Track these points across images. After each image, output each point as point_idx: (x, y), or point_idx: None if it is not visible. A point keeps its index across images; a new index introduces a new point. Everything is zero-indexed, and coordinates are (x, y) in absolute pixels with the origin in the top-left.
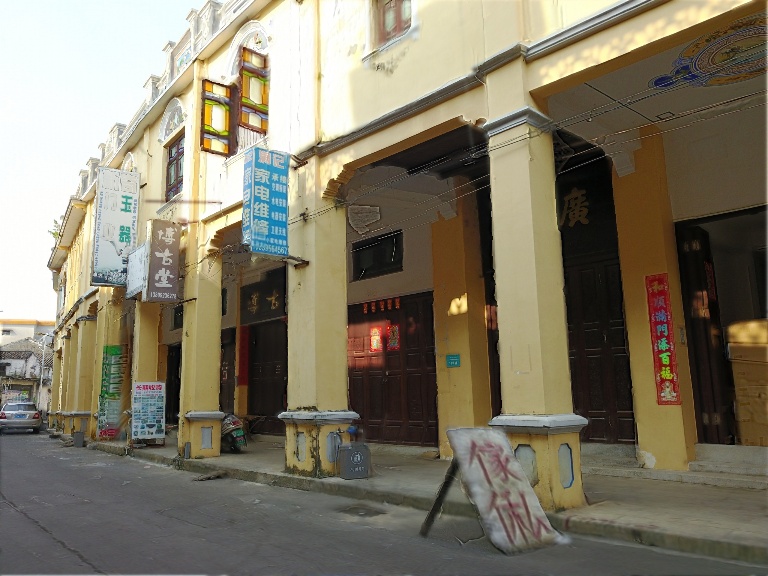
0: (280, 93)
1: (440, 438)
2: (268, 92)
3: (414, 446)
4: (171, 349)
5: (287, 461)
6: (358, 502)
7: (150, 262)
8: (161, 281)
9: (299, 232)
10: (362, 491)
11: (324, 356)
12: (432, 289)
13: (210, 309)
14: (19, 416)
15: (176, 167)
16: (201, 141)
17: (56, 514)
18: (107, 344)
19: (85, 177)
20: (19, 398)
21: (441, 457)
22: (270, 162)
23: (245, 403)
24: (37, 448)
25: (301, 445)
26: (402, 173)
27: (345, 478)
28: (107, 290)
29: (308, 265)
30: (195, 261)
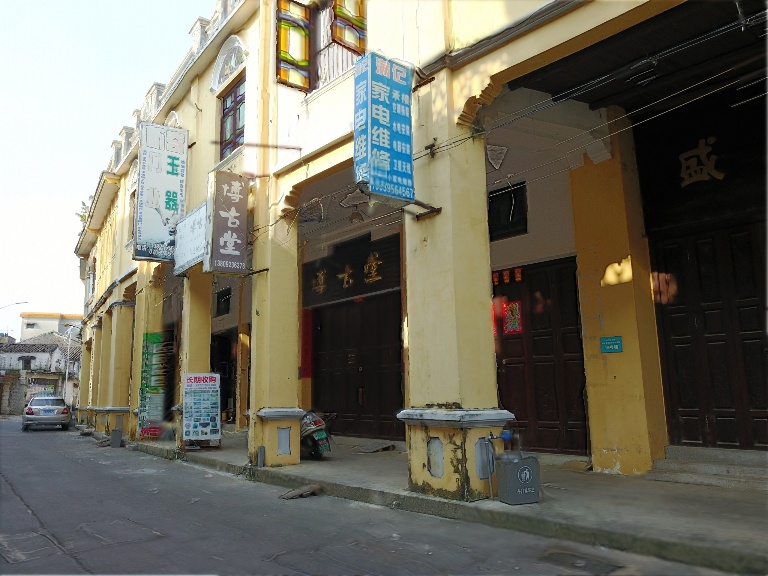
0: (384, 0)
1: (592, 444)
2: (366, 2)
3: (548, 453)
4: (213, 338)
5: (412, 476)
6: (550, 542)
7: (213, 223)
8: (227, 247)
9: (423, 172)
10: (550, 525)
11: (467, 335)
12: (570, 254)
13: (285, 282)
14: (47, 411)
15: (233, 118)
16: (277, 70)
17: (122, 560)
18: (147, 331)
19: (118, 148)
20: (44, 392)
21: (595, 469)
22: (389, 75)
23: (309, 398)
24: (70, 448)
25: (434, 455)
26: (546, 99)
27: (509, 503)
28: (146, 270)
29: (439, 213)
30: (266, 223)
